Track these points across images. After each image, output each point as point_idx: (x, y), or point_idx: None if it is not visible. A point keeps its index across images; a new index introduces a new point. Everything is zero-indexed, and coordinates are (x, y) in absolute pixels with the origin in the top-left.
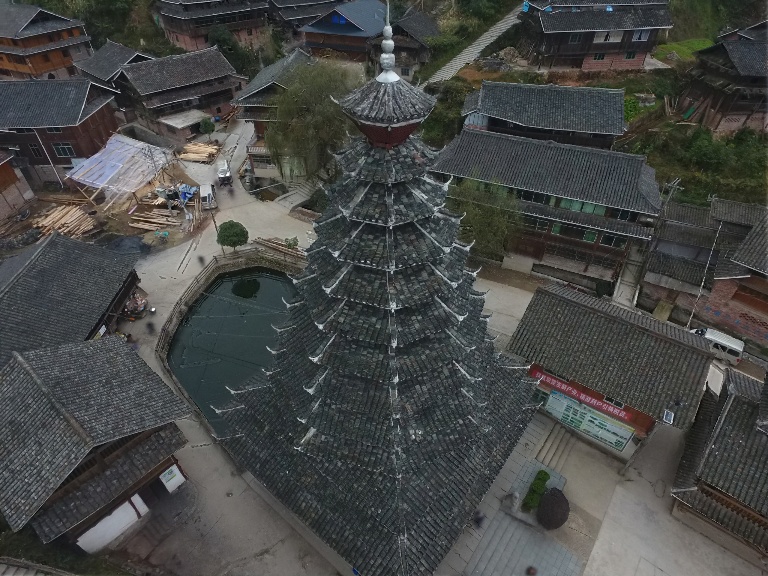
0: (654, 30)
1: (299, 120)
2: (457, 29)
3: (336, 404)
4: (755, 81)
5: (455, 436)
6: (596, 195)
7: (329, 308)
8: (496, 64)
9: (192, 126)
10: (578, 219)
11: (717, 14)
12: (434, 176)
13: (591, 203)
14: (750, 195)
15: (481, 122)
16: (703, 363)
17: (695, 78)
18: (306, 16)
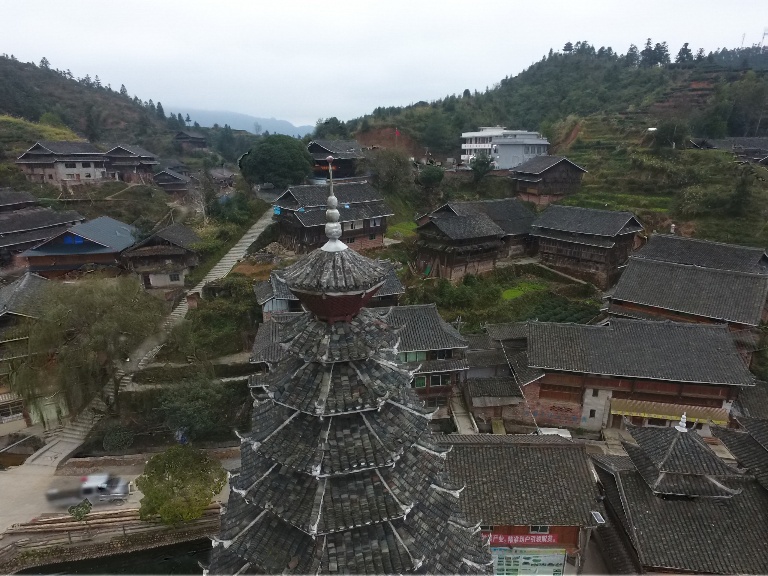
0: (383, 218)
1: (70, 346)
2: (218, 234)
3: None
4: (461, 242)
5: None
6: (415, 344)
7: (306, 558)
8: (268, 257)
9: None
10: None
11: (407, 206)
12: (242, 371)
13: None
14: (497, 318)
15: (280, 307)
16: (581, 455)
17: (422, 246)
18: (19, 243)
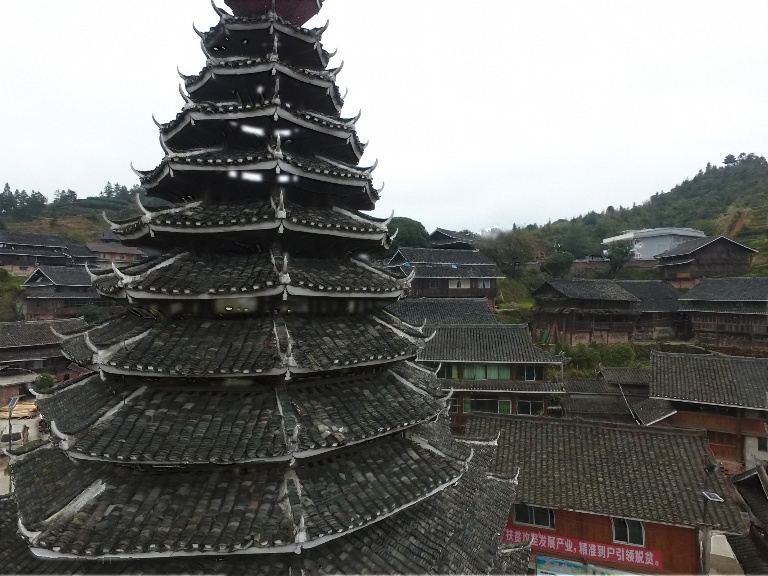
0: (492, 280)
1: None
2: None
3: (156, 408)
4: (582, 304)
5: (411, 477)
6: (496, 355)
7: None
8: None
9: (23, 385)
10: (486, 386)
11: None
12: None
13: (494, 363)
14: None
15: None
16: (700, 445)
17: (537, 312)
18: None
